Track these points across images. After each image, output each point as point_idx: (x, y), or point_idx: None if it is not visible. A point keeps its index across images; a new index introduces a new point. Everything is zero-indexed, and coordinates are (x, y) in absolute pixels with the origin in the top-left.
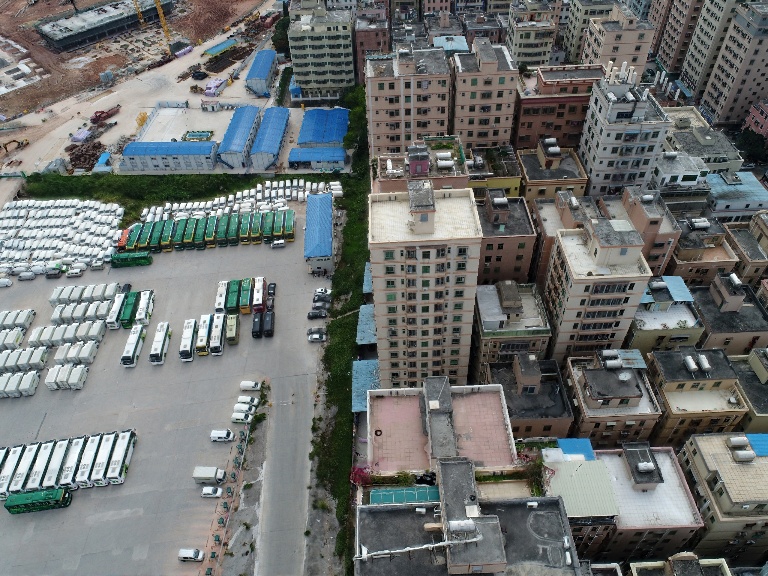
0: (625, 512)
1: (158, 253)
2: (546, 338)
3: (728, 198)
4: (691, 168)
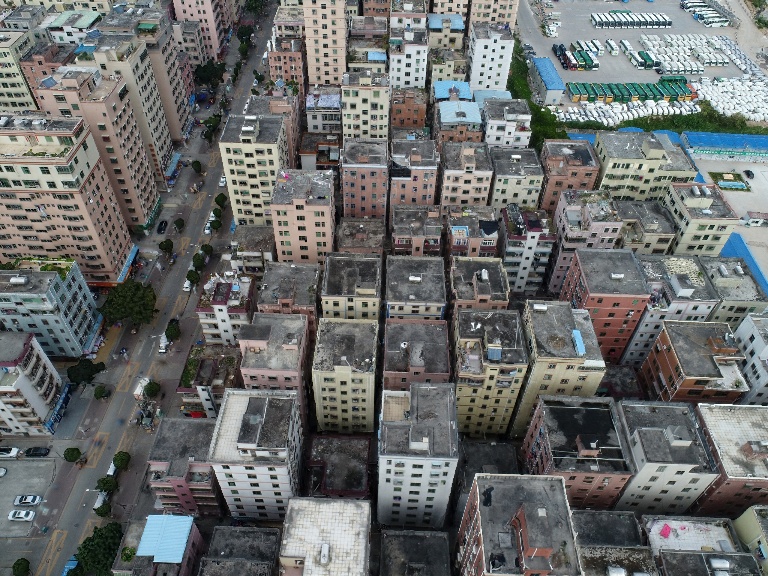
0: None
1: None
2: None
3: None
4: None
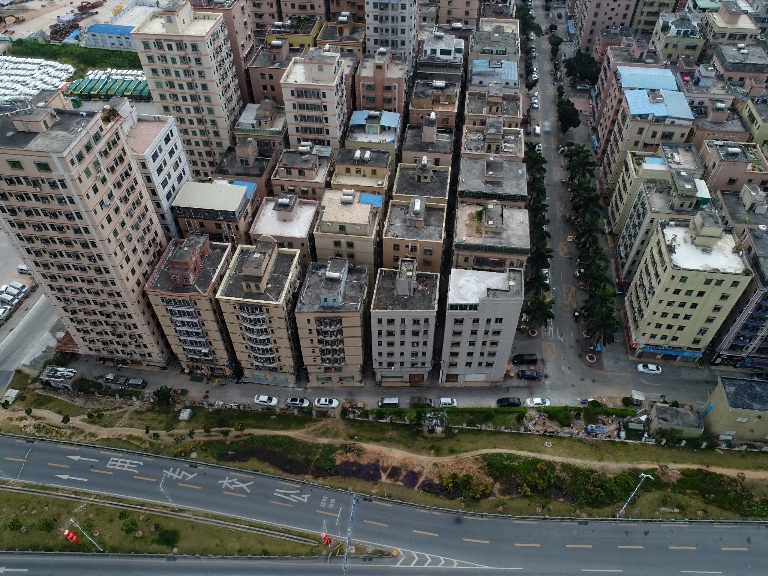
0: (263, 229)
1: (88, 101)
2: (280, 139)
3: (482, 75)
4: (449, 45)
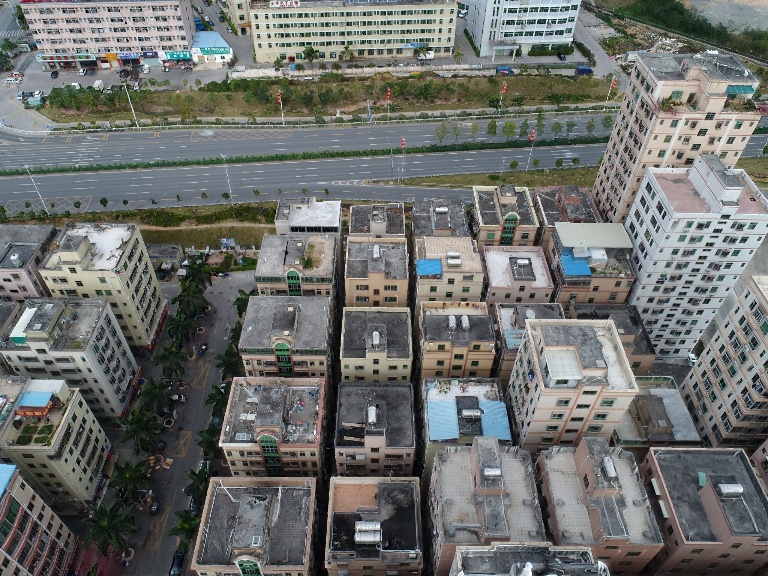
0: (533, 259)
1: None
2: None
3: None
4: None
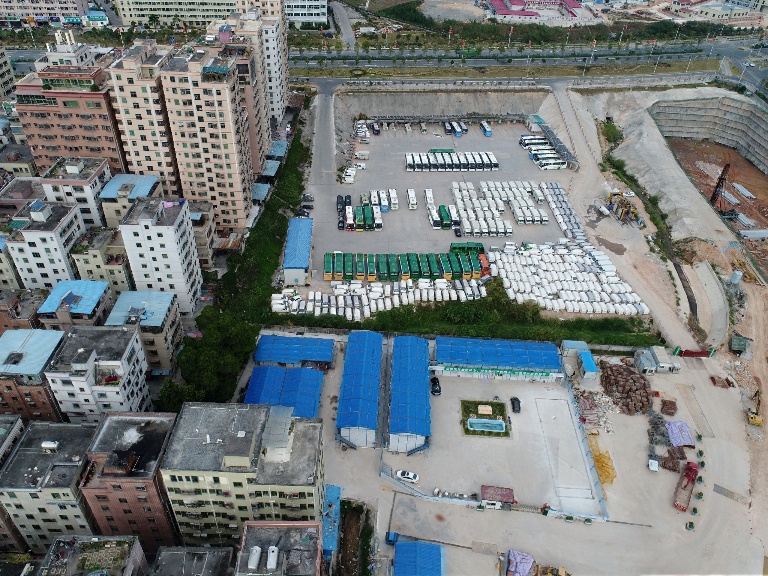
0: None
1: None
2: None
3: None
4: None
